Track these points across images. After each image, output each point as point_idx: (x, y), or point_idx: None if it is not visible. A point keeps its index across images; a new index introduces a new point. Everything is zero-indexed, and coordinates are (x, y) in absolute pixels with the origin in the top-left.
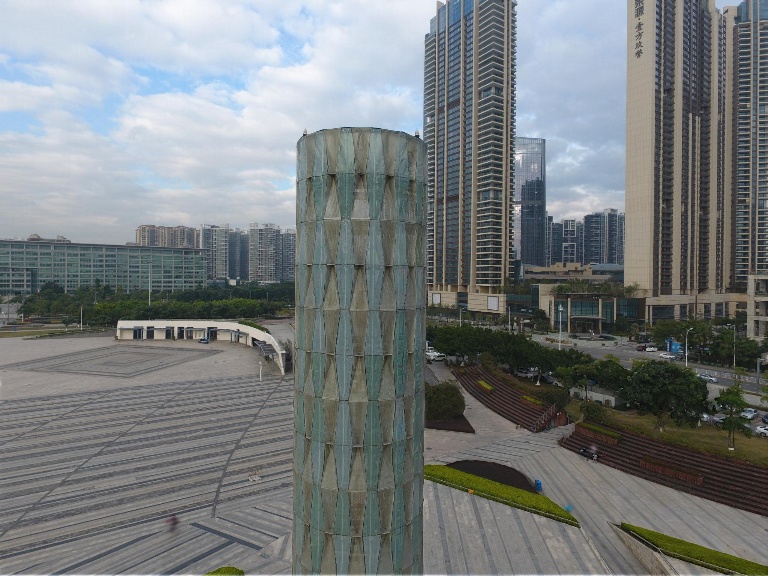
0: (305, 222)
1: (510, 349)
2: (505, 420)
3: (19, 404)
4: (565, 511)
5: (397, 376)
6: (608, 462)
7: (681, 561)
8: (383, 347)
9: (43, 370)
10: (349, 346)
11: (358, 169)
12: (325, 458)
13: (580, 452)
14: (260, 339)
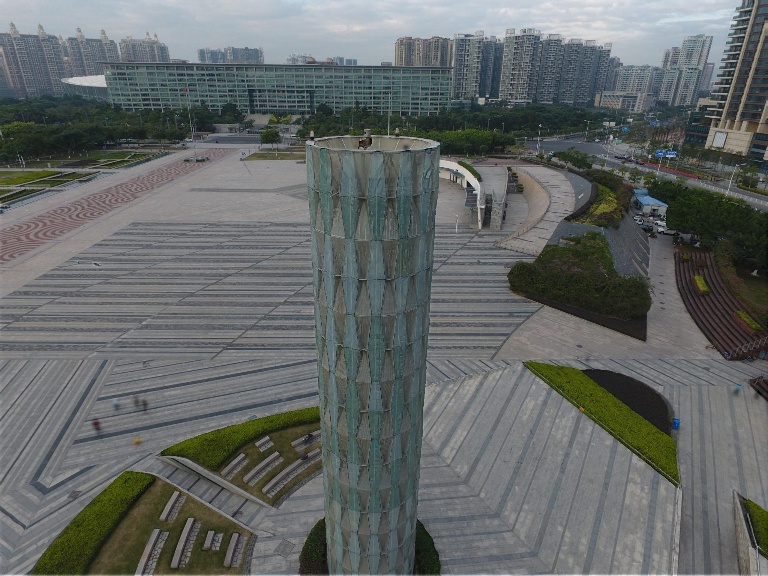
0: None
1: (762, 243)
2: (699, 334)
3: (278, 228)
4: (675, 464)
5: (375, 365)
6: None
7: None
8: (359, 343)
9: (300, 197)
10: (334, 336)
11: (337, 189)
12: (325, 403)
13: None
14: (472, 184)
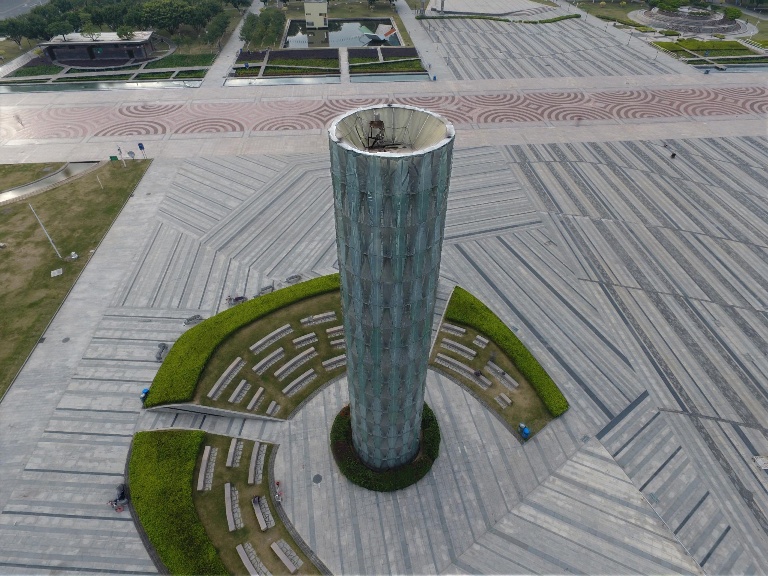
0: None
1: None
2: None
3: None
4: None
5: None
6: None
7: None
8: None
9: None
10: None
11: None
12: None
13: None
14: None
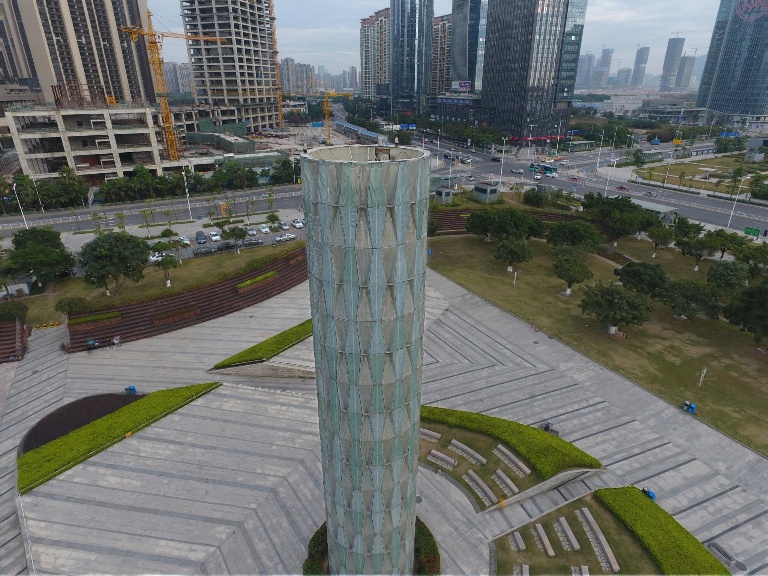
0: (406, 244)
1: None
2: None
3: None
4: (198, 385)
5: None
6: (130, 338)
7: (275, 357)
8: None
9: None
10: None
11: None
12: None
13: (97, 346)
14: None
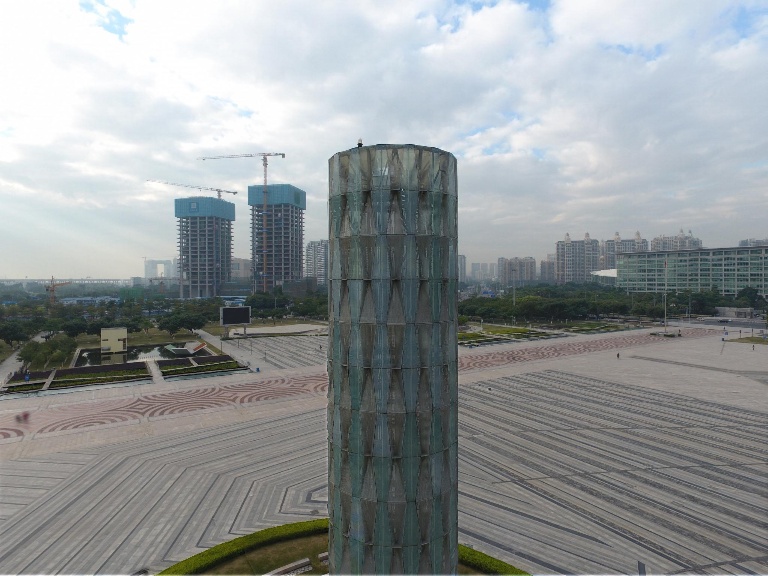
0: None
1: None
2: None
3: (699, 405)
4: None
5: None
6: None
7: None
8: (331, 353)
9: None
10: None
11: None
12: None
13: None
14: None
